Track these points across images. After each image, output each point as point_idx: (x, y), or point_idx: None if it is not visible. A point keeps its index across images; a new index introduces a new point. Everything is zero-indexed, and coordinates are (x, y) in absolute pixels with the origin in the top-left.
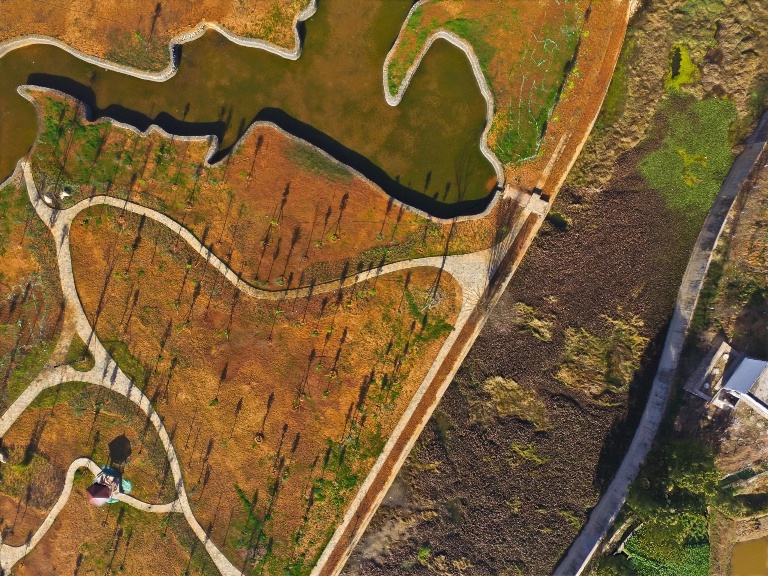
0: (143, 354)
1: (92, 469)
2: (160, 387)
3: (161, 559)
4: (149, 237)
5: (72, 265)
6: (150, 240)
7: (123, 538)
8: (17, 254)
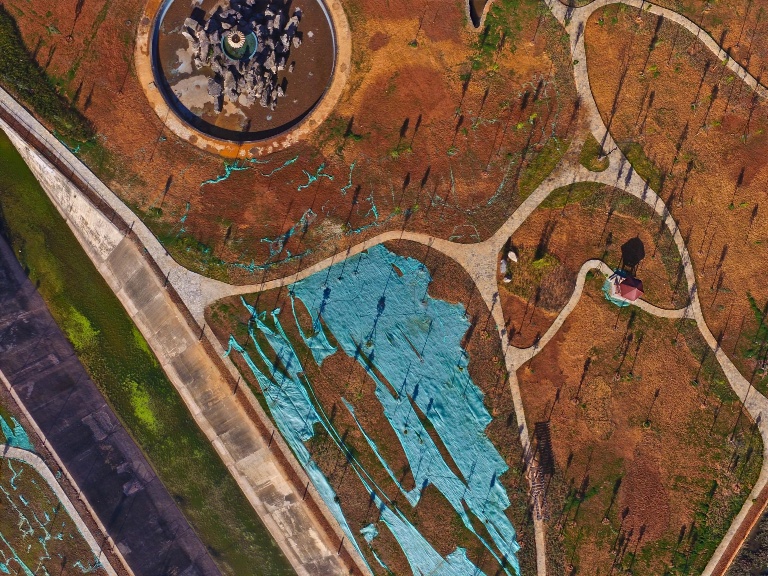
0: (659, 156)
1: (604, 271)
2: (675, 190)
3: (671, 366)
4: (667, 38)
5: (587, 64)
6: (667, 41)
7: (633, 343)
8: (528, 51)
